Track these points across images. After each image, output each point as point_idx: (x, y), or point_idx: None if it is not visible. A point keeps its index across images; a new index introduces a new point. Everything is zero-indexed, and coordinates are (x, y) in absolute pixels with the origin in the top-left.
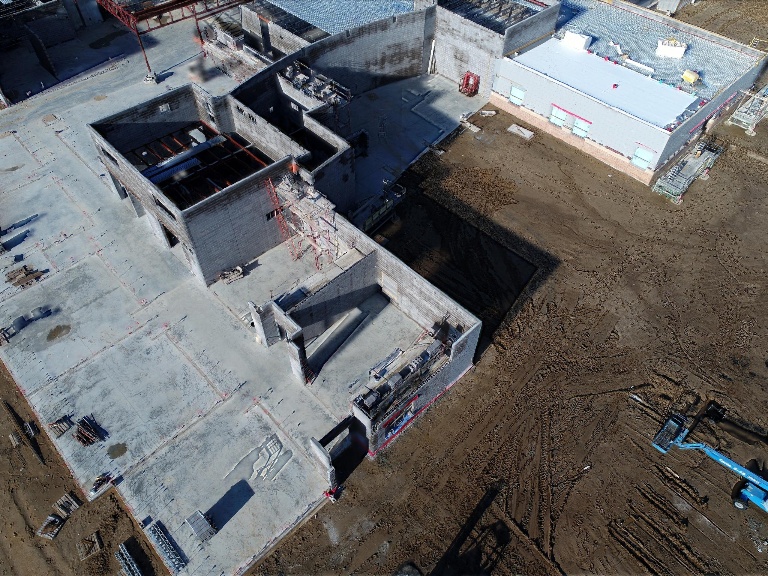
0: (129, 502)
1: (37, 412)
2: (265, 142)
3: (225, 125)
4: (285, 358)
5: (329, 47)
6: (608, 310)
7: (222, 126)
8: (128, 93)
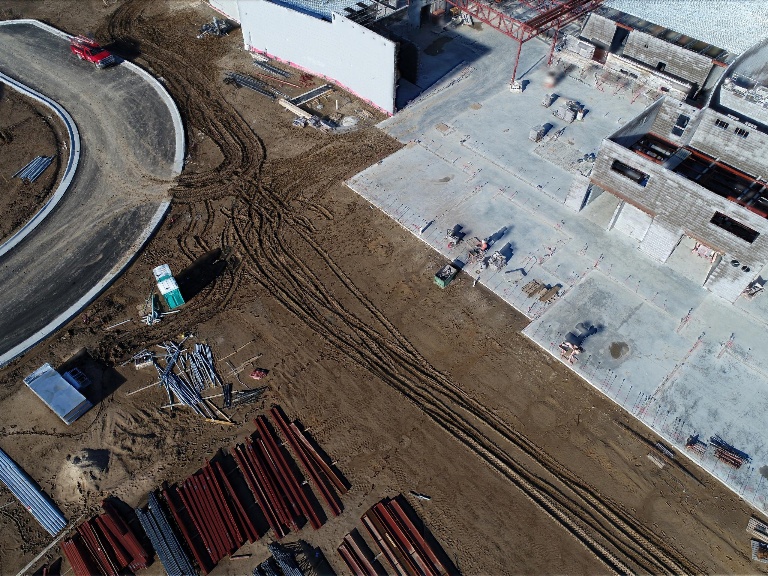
0: None
1: (660, 432)
2: (748, 156)
3: (688, 138)
4: None
5: (745, 58)
6: None
7: (686, 139)
8: (500, 102)
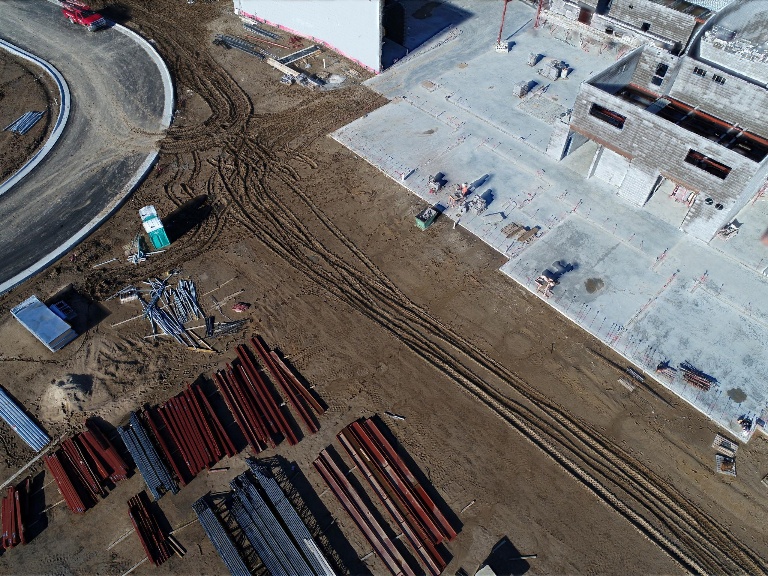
0: None
1: (632, 358)
2: (726, 103)
3: (667, 87)
4: None
5: (726, 13)
6: None
7: (666, 88)
8: (486, 61)
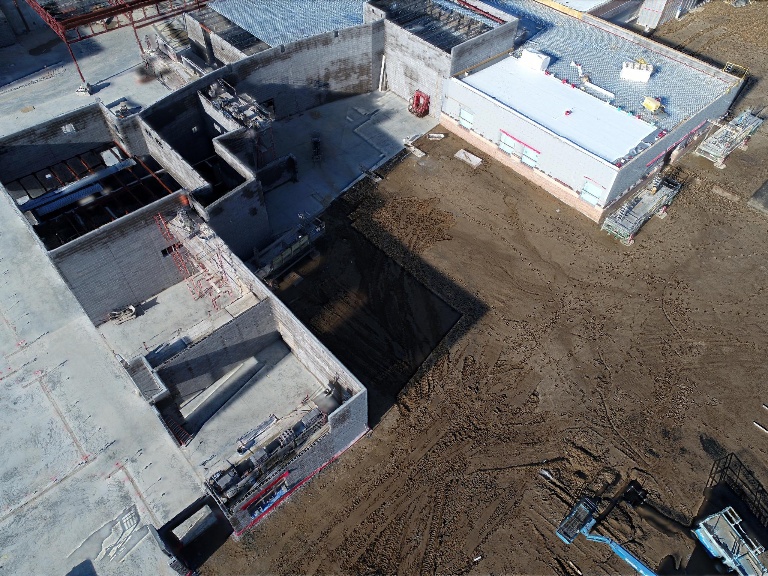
0: None
1: None
2: (173, 168)
3: (136, 147)
4: None
5: (261, 63)
6: (532, 368)
7: (132, 149)
8: (58, 105)
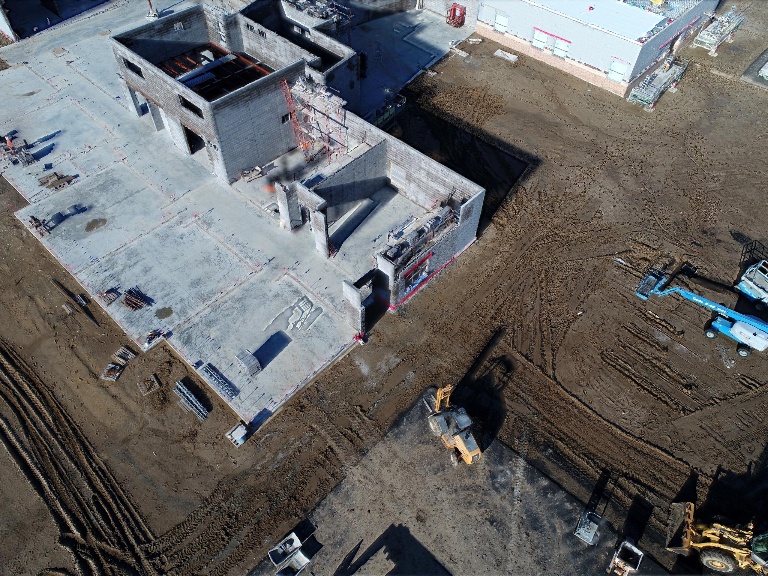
0: (181, 350)
1: (86, 286)
2: (274, 56)
3: (235, 44)
4: (308, 238)
5: None
6: (592, 196)
7: (232, 45)
8: None
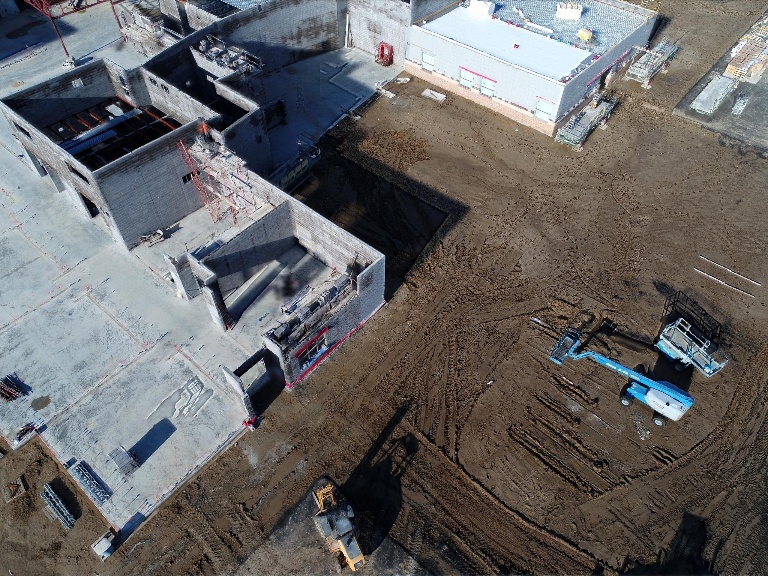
0: (53, 447)
1: None
2: (179, 111)
3: (140, 98)
4: (206, 309)
5: (242, 21)
6: (512, 247)
7: (137, 99)
8: None
